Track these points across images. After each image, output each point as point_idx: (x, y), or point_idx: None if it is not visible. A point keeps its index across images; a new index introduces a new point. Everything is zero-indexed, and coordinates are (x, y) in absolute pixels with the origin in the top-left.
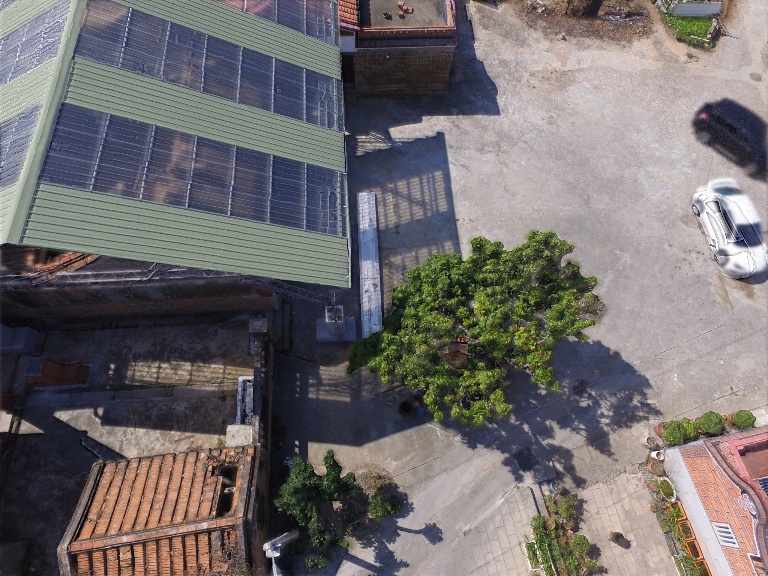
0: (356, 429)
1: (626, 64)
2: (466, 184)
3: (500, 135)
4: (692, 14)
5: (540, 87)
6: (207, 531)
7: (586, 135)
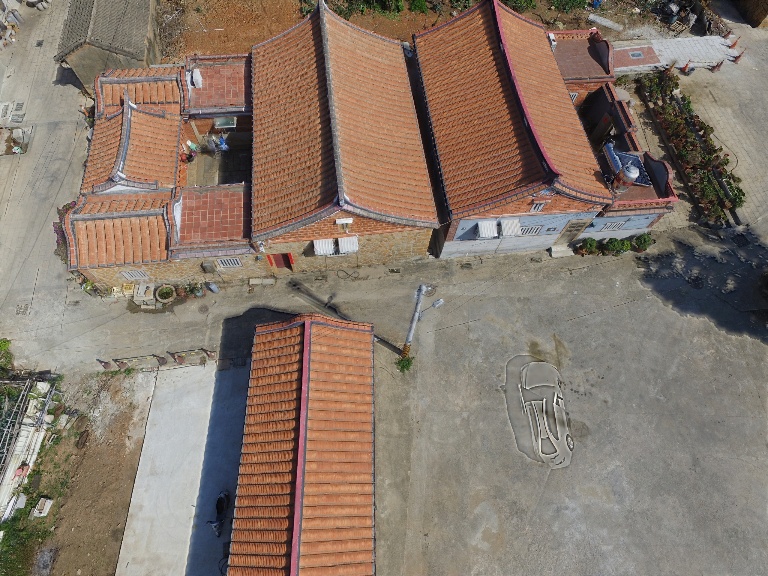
0: None
1: None
2: None
3: None
4: None
5: None
6: None
7: (699, 573)
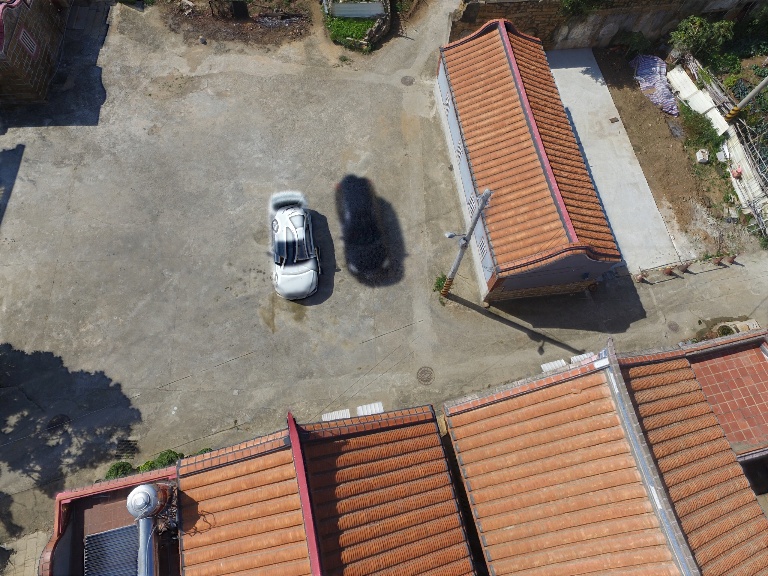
0: None
1: (262, 69)
2: (25, 201)
3: (88, 147)
4: (356, 14)
5: (157, 94)
6: None
7: (186, 145)
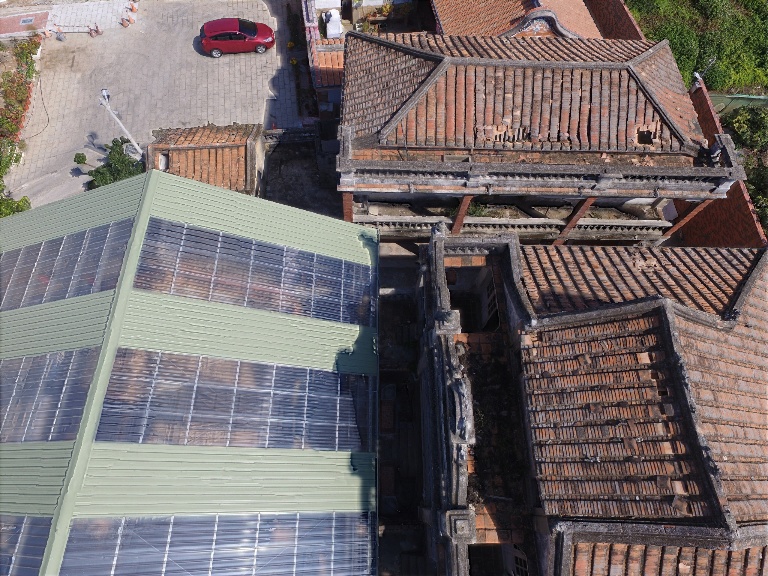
0: None
1: None
2: None
3: None
4: None
5: None
6: None
7: None
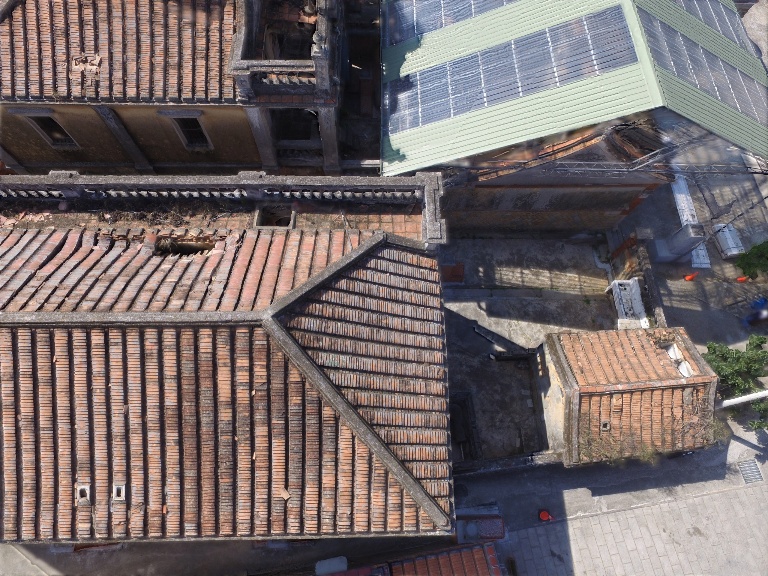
0: (713, 334)
1: None
2: None
3: None
4: None
5: None
6: (683, 387)
7: None
